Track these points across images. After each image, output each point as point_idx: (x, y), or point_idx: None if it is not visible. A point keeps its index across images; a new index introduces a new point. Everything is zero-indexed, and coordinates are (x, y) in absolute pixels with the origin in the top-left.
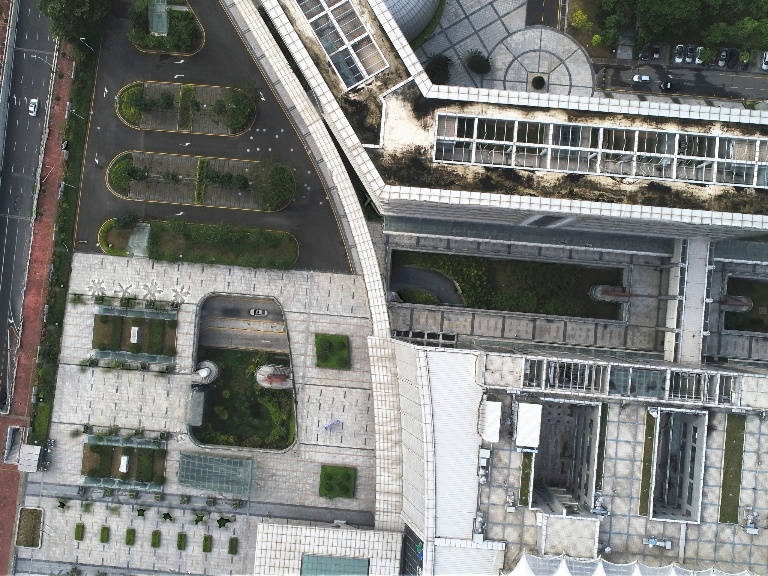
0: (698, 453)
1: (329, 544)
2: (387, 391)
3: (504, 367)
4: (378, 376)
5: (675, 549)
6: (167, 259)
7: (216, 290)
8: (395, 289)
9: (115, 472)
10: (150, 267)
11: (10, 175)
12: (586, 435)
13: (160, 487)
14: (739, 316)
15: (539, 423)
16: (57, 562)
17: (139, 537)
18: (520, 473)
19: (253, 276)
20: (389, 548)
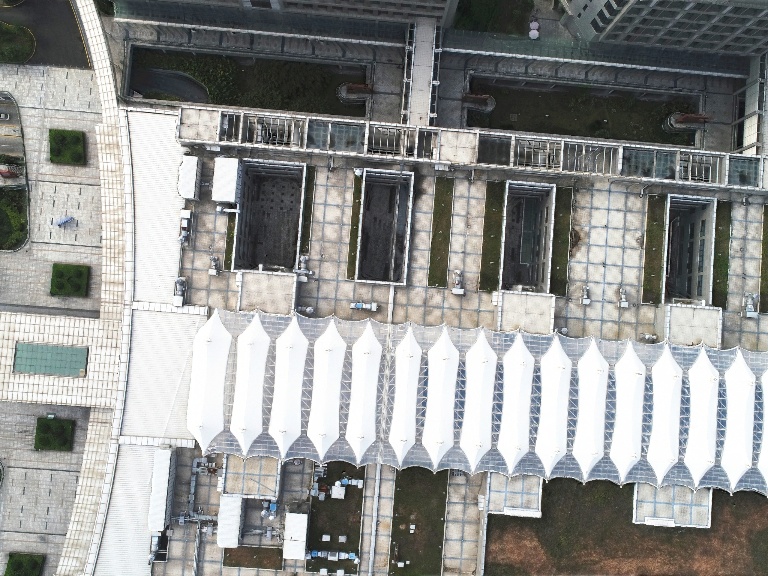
0: None
1: (45, 332)
2: (115, 179)
3: (200, 121)
4: (106, 164)
5: (384, 314)
6: None
7: None
8: (142, 92)
9: None
10: None
11: None
12: None
13: None
14: (486, 118)
15: (235, 177)
16: None
17: None
18: (225, 237)
19: None
20: (110, 336)
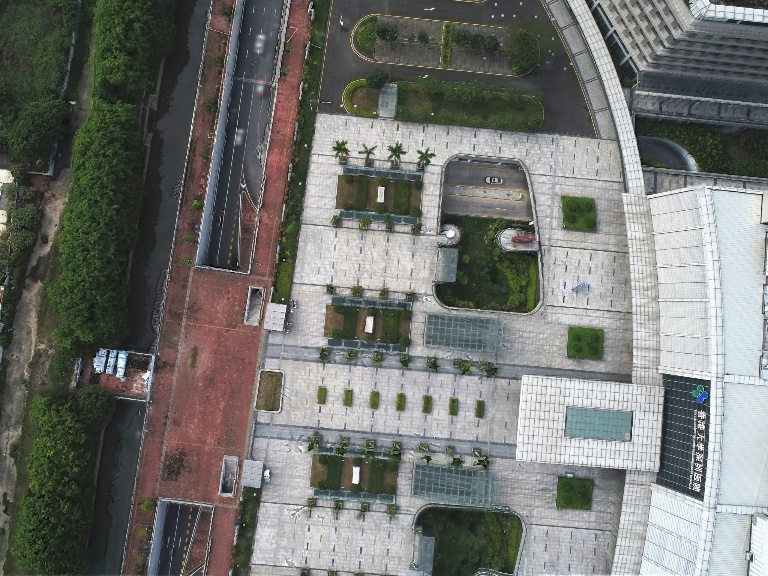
0: None
1: (593, 397)
2: (643, 247)
3: None
4: (634, 232)
5: None
6: (414, 119)
7: (462, 152)
8: None
9: (359, 334)
10: (395, 128)
11: (247, 38)
12: None
13: (405, 349)
14: None
15: None
16: (298, 427)
17: (383, 400)
18: None
19: (498, 139)
20: (652, 401)
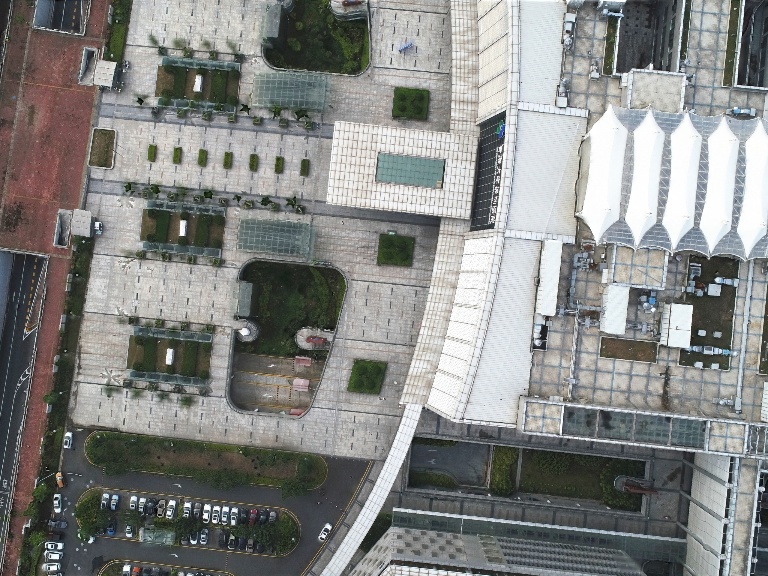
0: None
1: (405, 144)
2: (465, 1)
3: None
4: None
5: None
6: None
7: None
8: None
9: (189, 94)
10: None
11: None
12: (668, 23)
13: (233, 109)
14: None
15: None
16: None
17: (211, 159)
18: (604, 43)
19: None
20: (465, 150)
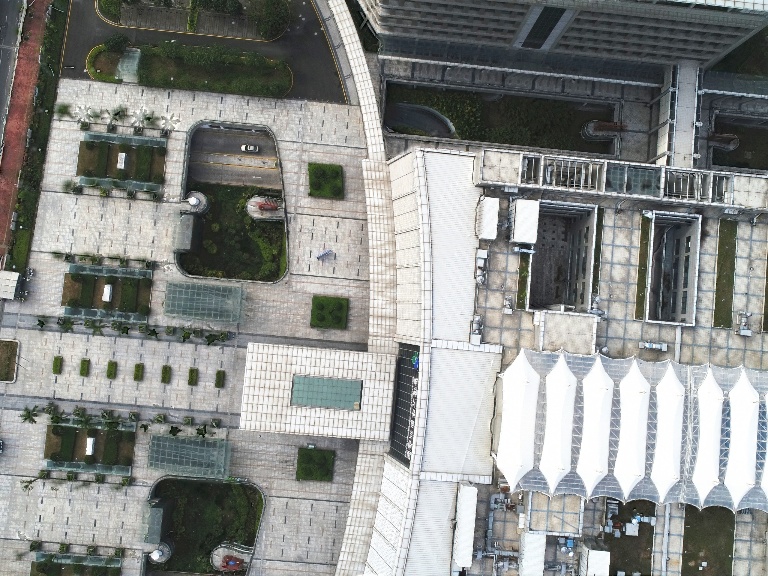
0: (692, 259)
1: (321, 365)
2: (381, 214)
3: (502, 163)
4: (372, 199)
5: (671, 354)
6: (157, 85)
7: (207, 118)
8: (389, 126)
9: (97, 302)
10: (139, 94)
11: None
12: (581, 248)
13: (145, 318)
14: (726, 156)
15: (537, 219)
16: (33, 397)
17: (121, 370)
18: (517, 277)
19: (246, 105)
20: (383, 370)
